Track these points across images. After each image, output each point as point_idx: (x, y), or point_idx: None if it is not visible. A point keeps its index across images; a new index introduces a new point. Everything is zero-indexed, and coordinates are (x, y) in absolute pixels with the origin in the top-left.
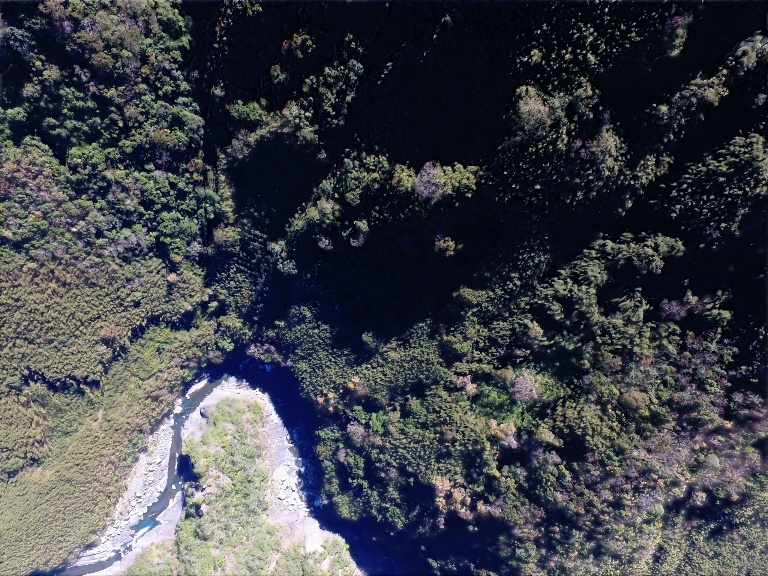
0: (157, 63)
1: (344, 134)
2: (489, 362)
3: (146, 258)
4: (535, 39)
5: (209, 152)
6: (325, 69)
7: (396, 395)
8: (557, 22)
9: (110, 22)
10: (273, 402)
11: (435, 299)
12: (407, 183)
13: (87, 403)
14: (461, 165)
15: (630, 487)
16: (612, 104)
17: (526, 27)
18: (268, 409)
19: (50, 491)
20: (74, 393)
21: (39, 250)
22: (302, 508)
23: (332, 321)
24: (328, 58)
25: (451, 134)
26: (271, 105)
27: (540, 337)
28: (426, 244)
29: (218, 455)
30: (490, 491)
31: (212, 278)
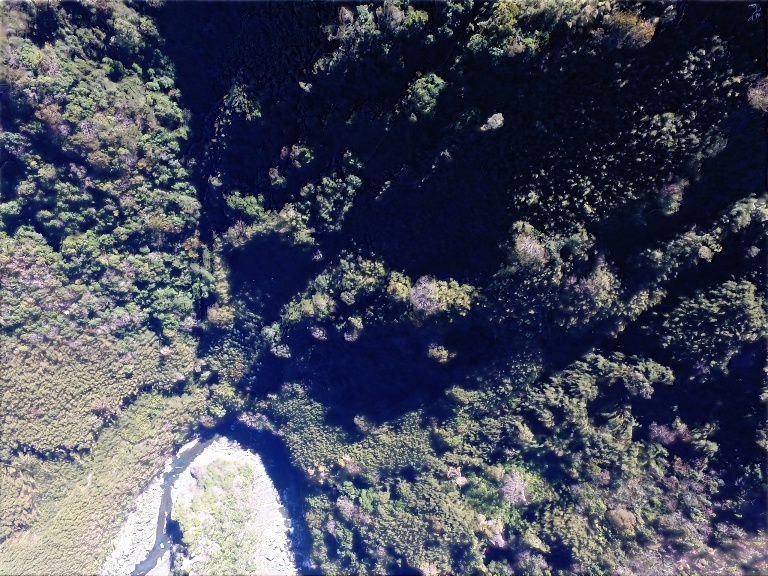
0: (154, 156)
1: (341, 235)
2: (479, 455)
3: (139, 332)
4: (533, 181)
5: (205, 231)
6: (323, 179)
7: (386, 476)
8: (555, 169)
9: (107, 123)
10: (264, 463)
11: (427, 392)
12: (402, 293)
13: (77, 468)
14: (456, 282)
15: None
16: (607, 245)
17: (524, 168)
18: (259, 470)
19: (37, 556)
20: (64, 460)
21: (31, 334)
22: (290, 568)
23: (324, 400)
24: (326, 167)
25: (447, 249)
26: (268, 201)
27: (530, 440)
28: (420, 345)
29: (207, 524)
30: None
31: (205, 350)
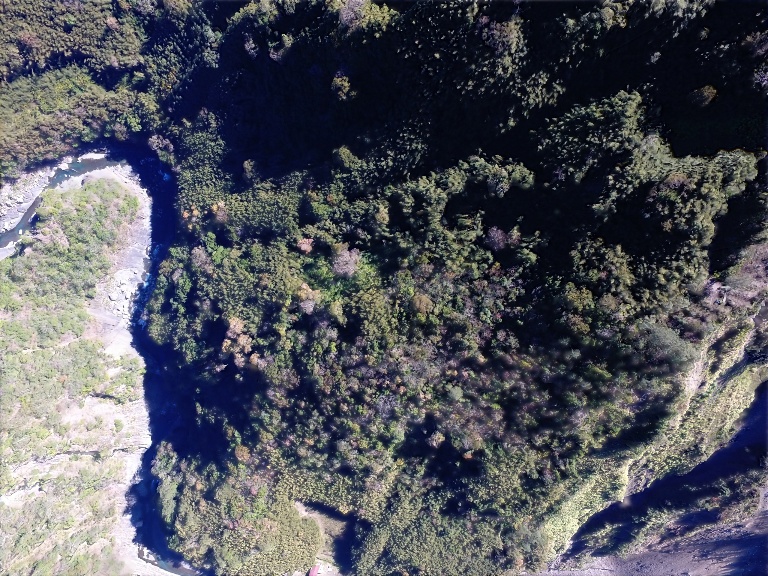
0: None
1: None
2: (335, 236)
3: None
4: None
5: None
6: None
7: (247, 236)
8: None
9: None
10: (153, 209)
11: (320, 153)
12: (336, 5)
13: None
14: (387, 7)
15: (375, 383)
16: None
17: None
18: (145, 212)
19: None
20: None
21: None
22: (125, 318)
23: (229, 139)
24: None
25: None
26: None
27: (384, 226)
28: None
29: (67, 211)
30: (270, 348)
31: (149, 47)
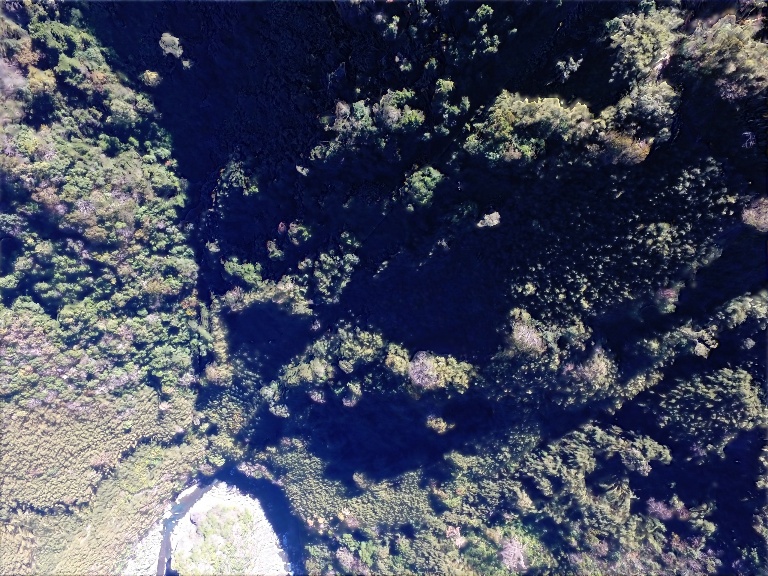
0: (151, 226)
1: (339, 305)
2: (478, 516)
3: (137, 389)
4: (530, 274)
5: (203, 289)
6: (321, 256)
7: (386, 531)
8: (552, 264)
9: (104, 200)
10: (263, 508)
11: (426, 453)
12: (400, 367)
13: (76, 521)
14: (454, 360)
15: None
16: (604, 333)
17: (521, 260)
18: (258, 515)
19: None
20: (63, 513)
21: (29, 399)
22: None
23: (323, 455)
24: (324, 243)
25: (445, 325)
26: (266, 270)
27: (529, 505)
28: (418, 412)
29: (207, 575)
30: None
31: (204, 403)
